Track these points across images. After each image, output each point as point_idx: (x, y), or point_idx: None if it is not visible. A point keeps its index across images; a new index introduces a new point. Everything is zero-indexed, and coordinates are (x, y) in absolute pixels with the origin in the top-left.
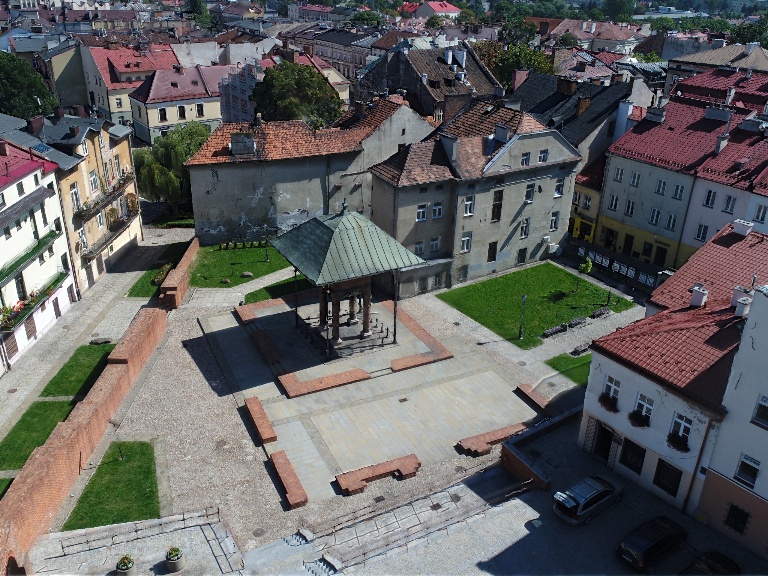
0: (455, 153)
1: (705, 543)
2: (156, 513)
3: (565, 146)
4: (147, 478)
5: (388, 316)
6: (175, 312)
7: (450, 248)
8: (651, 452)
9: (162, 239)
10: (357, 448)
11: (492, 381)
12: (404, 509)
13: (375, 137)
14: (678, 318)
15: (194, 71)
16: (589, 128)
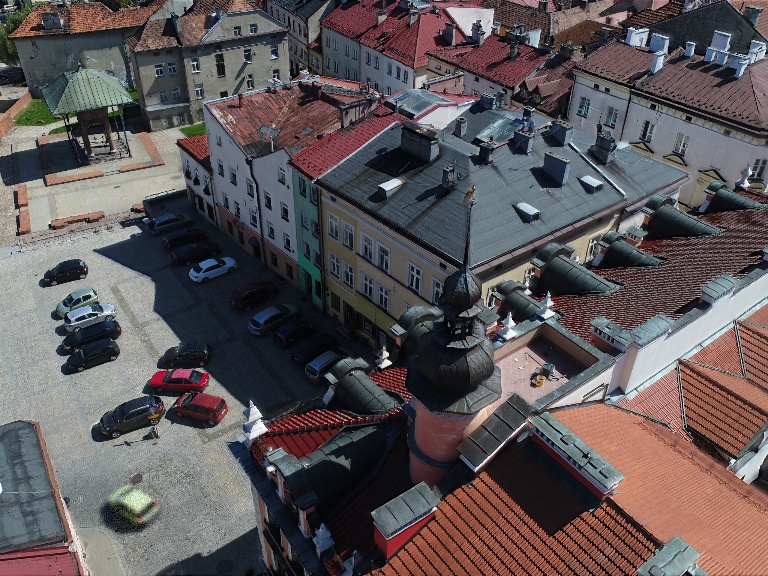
0: None
1: (217, 241)
2: None
3: (272, 21)
4: None
5: (137, 141)
6: None
7: (188, 96)
8: (204, 199)
9: (16, 95)
10: (74, 209)
11: (179, 177)
12: (78, 233)
13: (160, 14)
14: None
15: None
16: (320, 5)
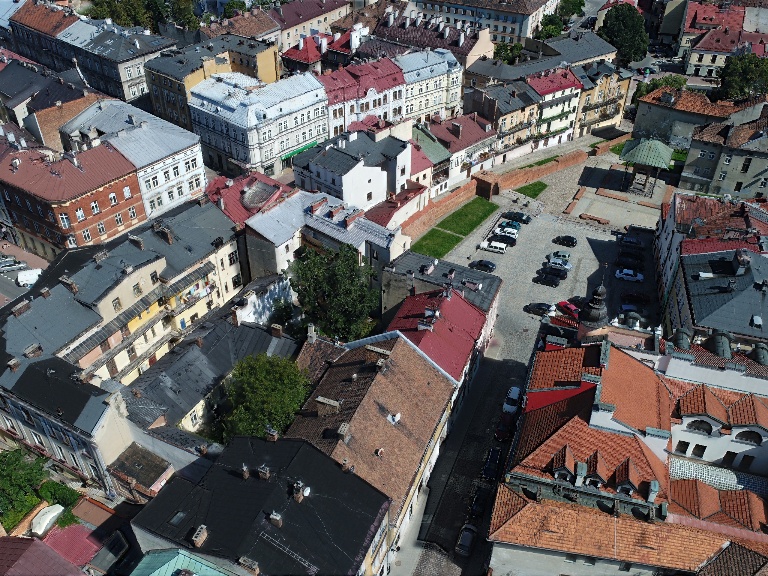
0: None
1: None
2: (534, 198)
3: None
4: (539, 191)
5: (664, 190)
6: (594, 157)
7: None
8: None
9: (628, 129)
10: (598, 213)
11: None
12: (589, 225)
13: (741, 114)
14: None
15: (737, 34)
16: None
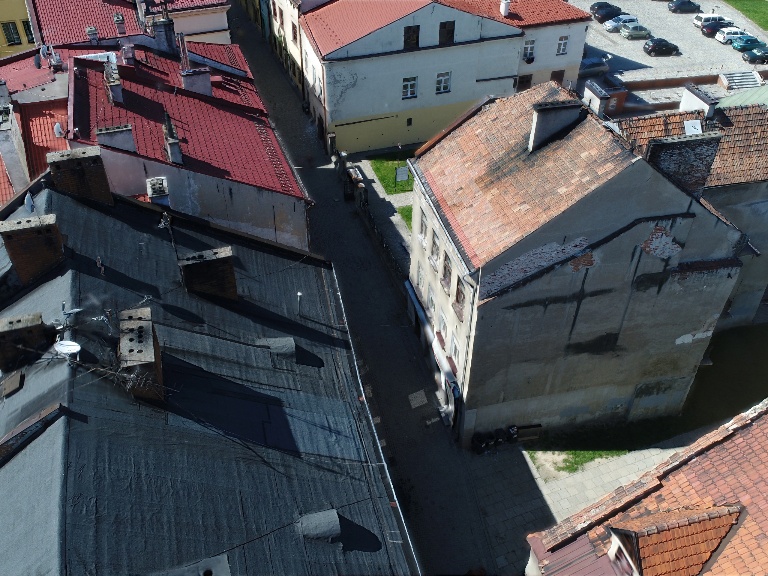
0: (681, 110)
1: None
2: None
3: None
4: None
5: None
6: None
7: None
8: None
9: None
10: None
11: None
12: None
13: None
14: (531, 7)
15: None
16: (262, 259)
